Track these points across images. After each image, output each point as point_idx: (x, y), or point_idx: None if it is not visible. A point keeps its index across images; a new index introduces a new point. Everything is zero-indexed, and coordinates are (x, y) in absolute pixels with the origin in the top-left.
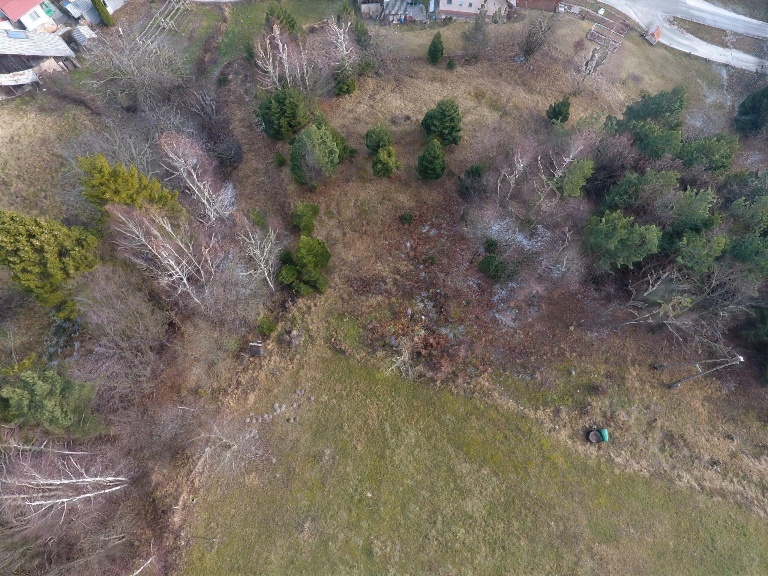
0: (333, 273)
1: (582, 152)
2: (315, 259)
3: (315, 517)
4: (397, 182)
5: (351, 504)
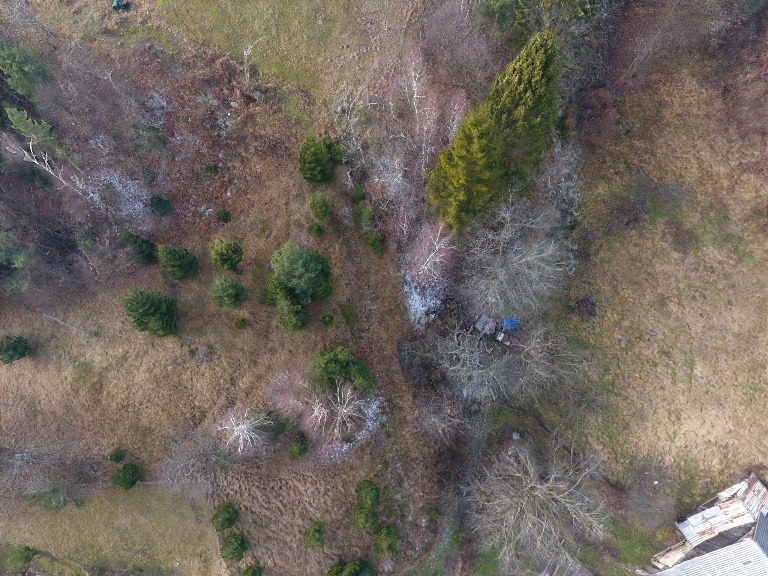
0: None
1: (11, 218)
2: None
3: None
4: None
5: None
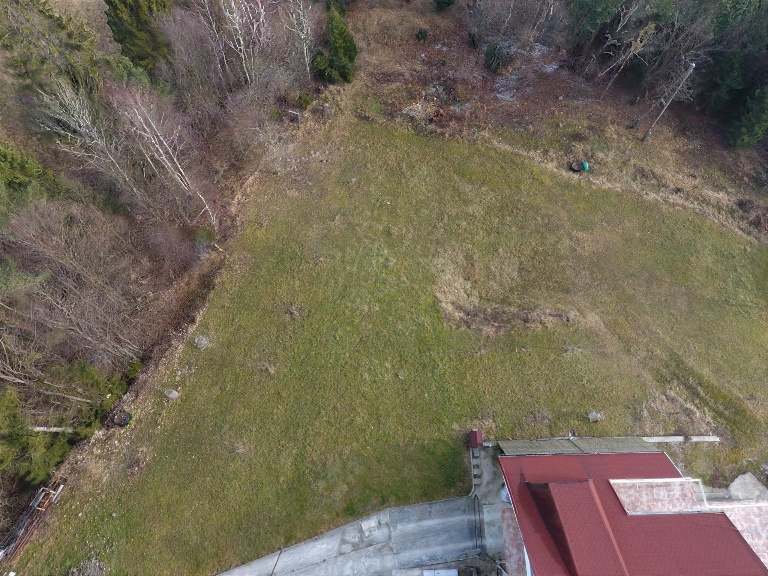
0: (359, 70)
1: None
2: (345, 45)
3: (344, 214)
4: (414, 11)
5: (373, 208)
